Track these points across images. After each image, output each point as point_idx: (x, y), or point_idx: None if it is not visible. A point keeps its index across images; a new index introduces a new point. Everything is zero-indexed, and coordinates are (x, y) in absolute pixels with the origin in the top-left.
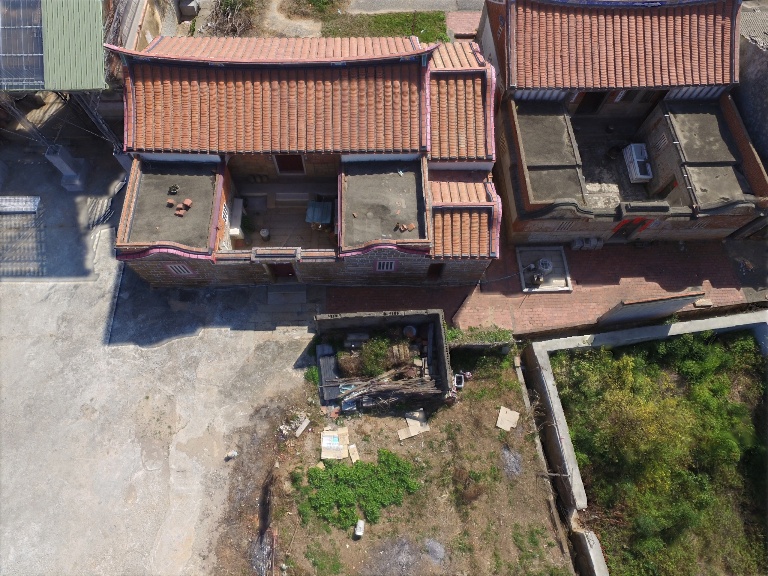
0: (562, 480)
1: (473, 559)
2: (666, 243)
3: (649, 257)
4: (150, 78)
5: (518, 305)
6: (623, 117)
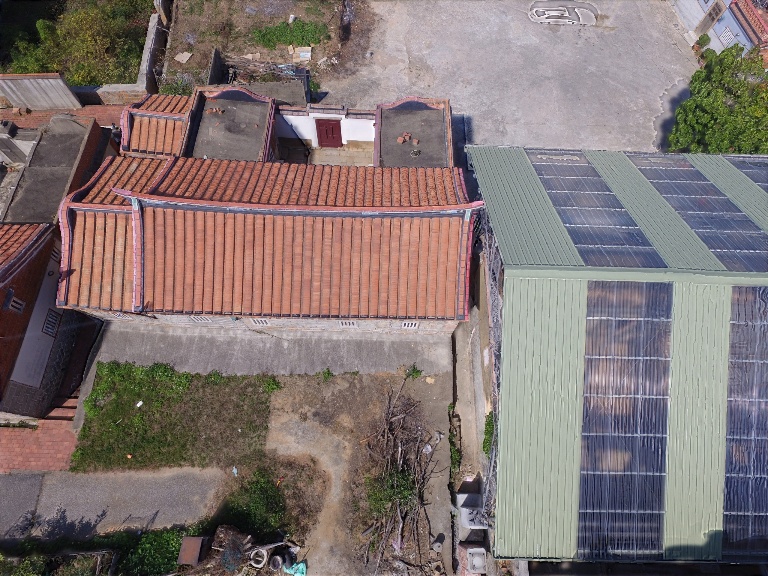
0: None
1: (230, 5)
2: None
3: None
4: None
5: None
6: None
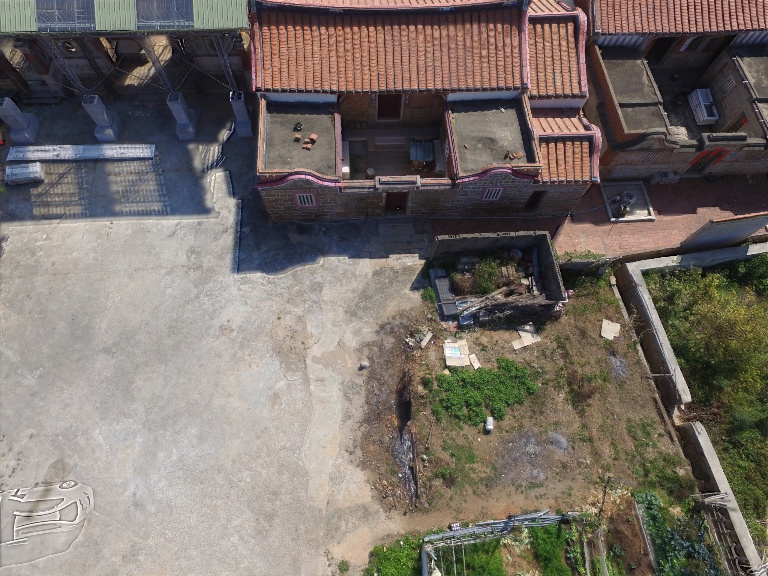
0: (666, 378)
1: (593, 448)
2: (735, 177)
3: (721, 189)
4: (275, 24)
5: (607, 233)
6: (685, 67)
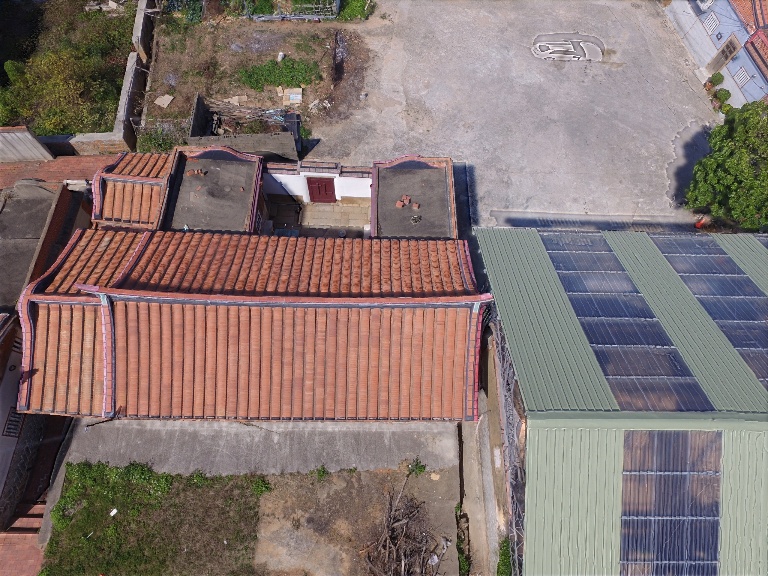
0: None
1: (214, 42)
2: None
3: None
4: (448, 293)
5: None
6: None
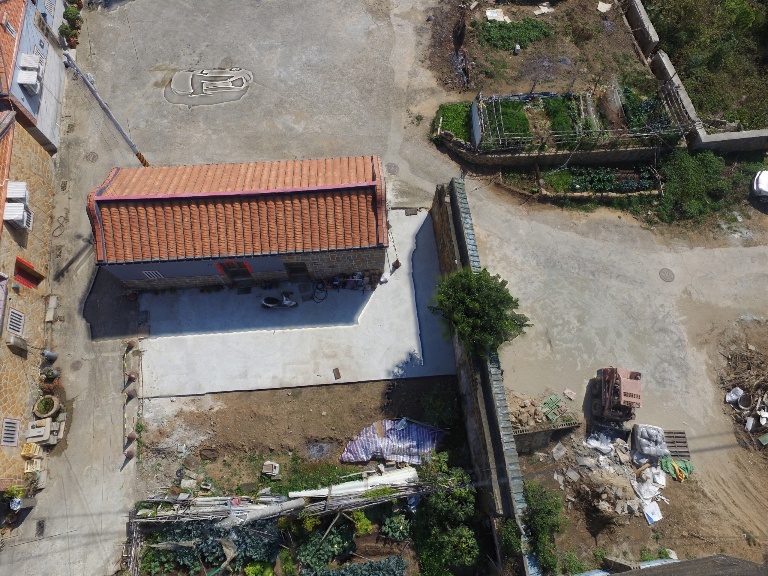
0: (642, 29)
1: (589, 64)
2: None
3: None
4: None
5: None
6: None
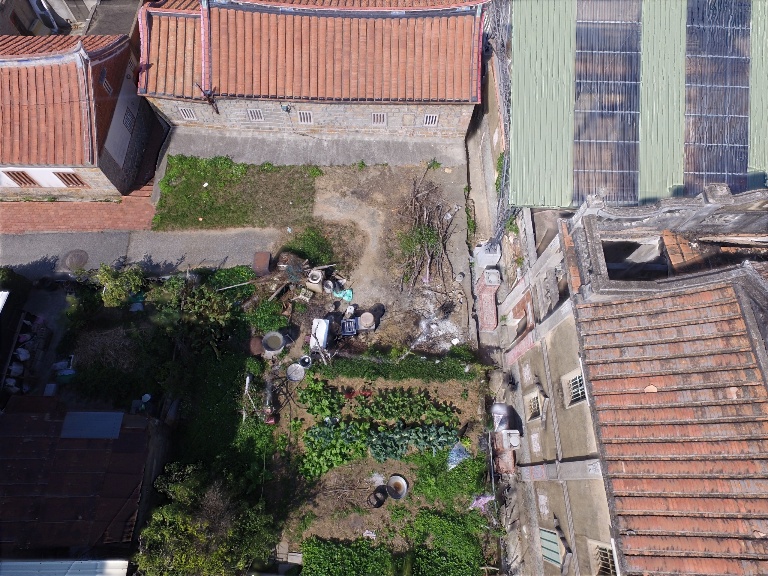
0: None
1: None
2: None
3: None
4: None
5: None
6: None
